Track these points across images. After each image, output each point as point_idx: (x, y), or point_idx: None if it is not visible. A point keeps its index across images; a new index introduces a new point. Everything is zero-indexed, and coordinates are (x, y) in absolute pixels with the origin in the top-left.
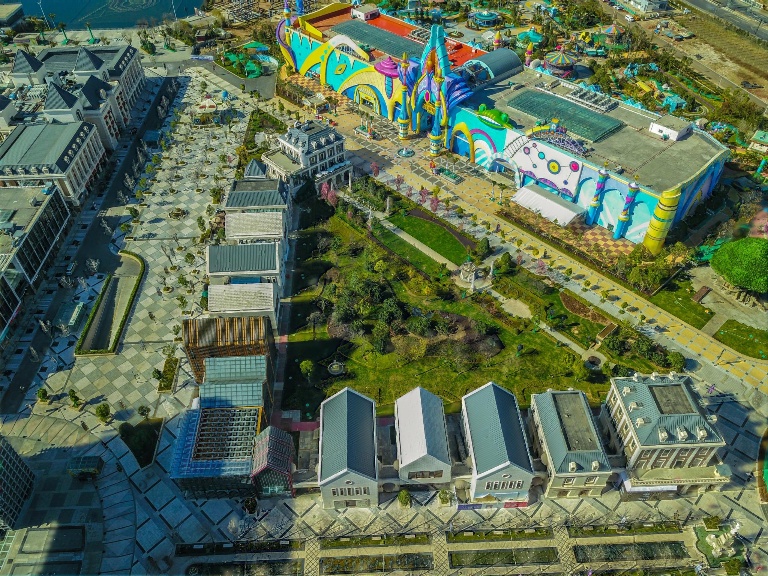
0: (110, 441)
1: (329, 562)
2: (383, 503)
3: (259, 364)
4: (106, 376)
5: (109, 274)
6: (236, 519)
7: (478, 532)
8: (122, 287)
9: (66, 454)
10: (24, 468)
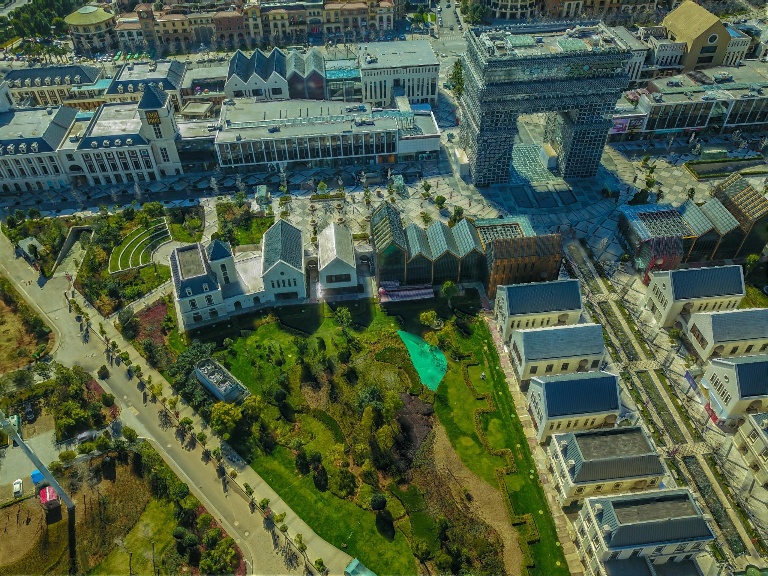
0: (633, 196)
1: (607, 306)
2: (665, 330)
3: (731, 224)
4: (678, 181)
5: (766, 158)
6: (613, 259)
7: (673, 389)
8: (759, 168)
9: (615, 183)
10: (596, 164)
